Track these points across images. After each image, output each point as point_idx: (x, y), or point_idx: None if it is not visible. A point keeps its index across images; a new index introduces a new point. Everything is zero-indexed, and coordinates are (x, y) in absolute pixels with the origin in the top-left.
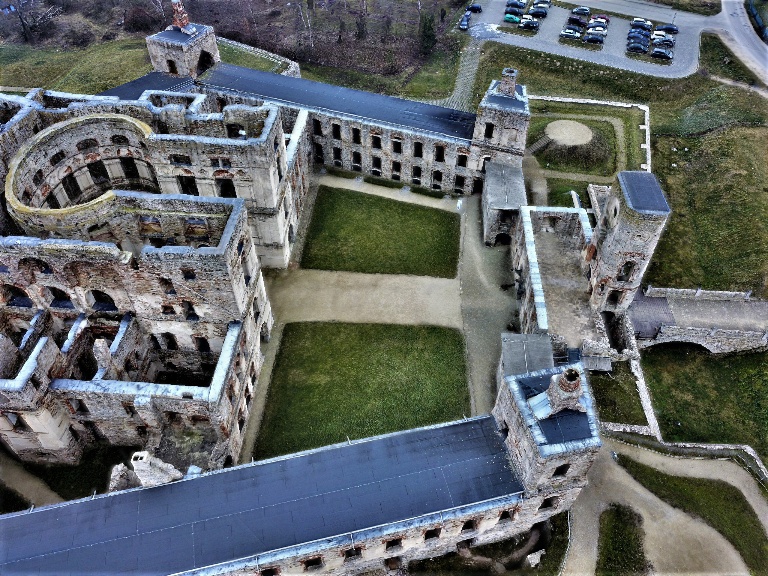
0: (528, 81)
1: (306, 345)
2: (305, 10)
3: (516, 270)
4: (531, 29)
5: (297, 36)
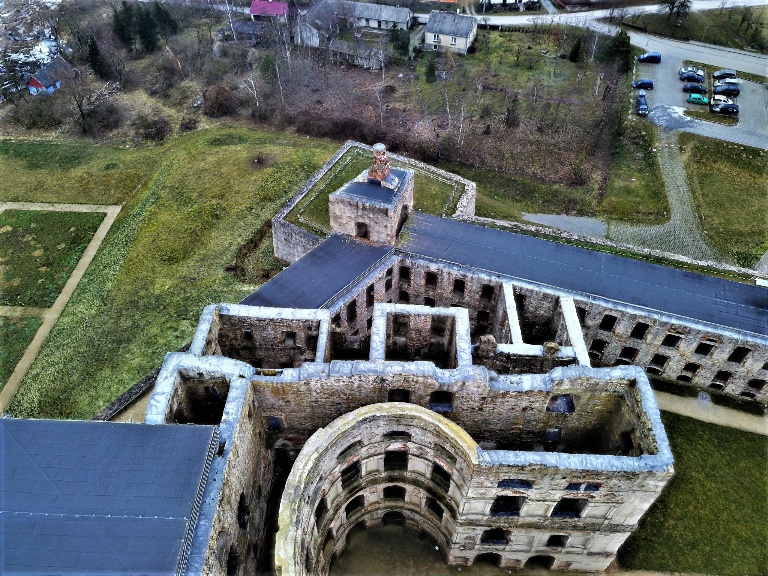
0: (756, 192)
1: None
2: (424, 84)
3: None
4: (730, 114)
5: (428, 123)
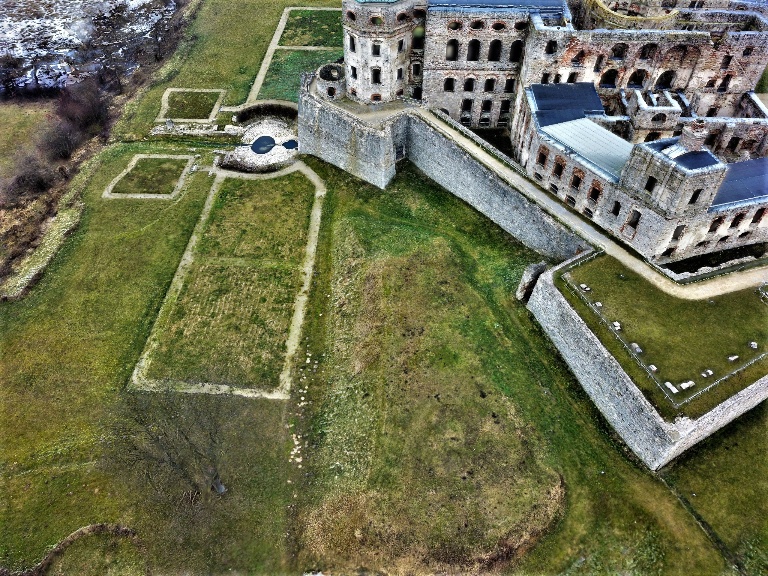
0: None
1: None
2: None
3: None
4: None
5: None
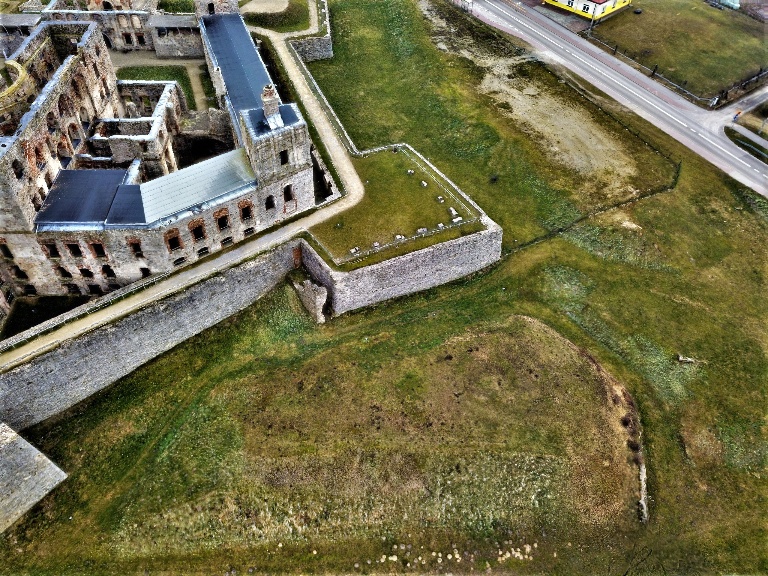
0: None
1: None
2: None
3: None
4: None
5: None
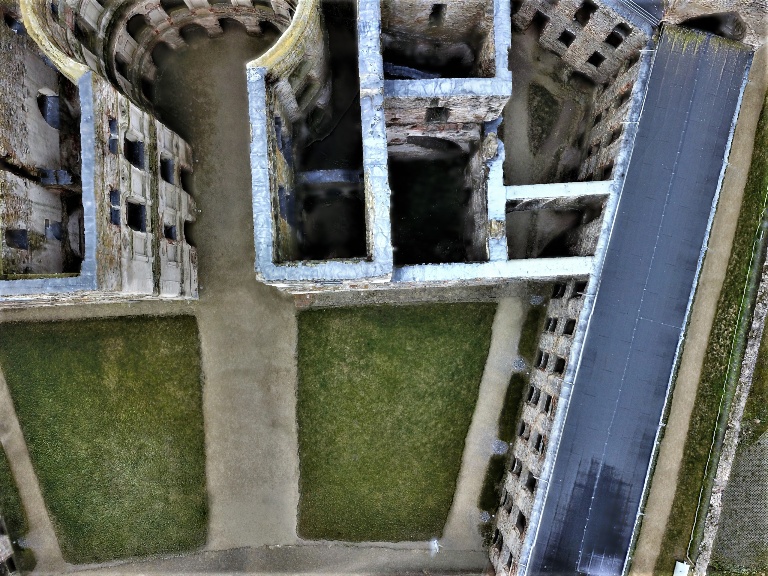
0: None
1: (161, 350)
2: None
3: None
4: None
5: None
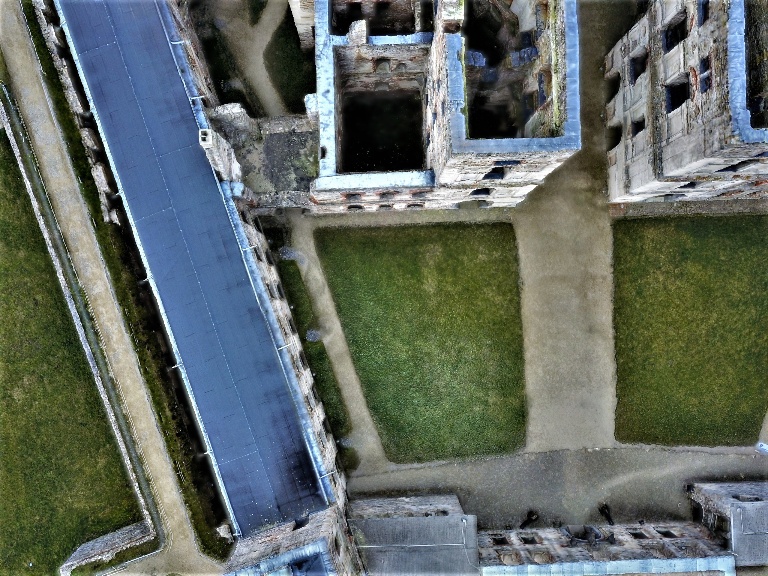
0: None
1: (480, 256)
2: None
3: (613, 535)
4: None
5: None
